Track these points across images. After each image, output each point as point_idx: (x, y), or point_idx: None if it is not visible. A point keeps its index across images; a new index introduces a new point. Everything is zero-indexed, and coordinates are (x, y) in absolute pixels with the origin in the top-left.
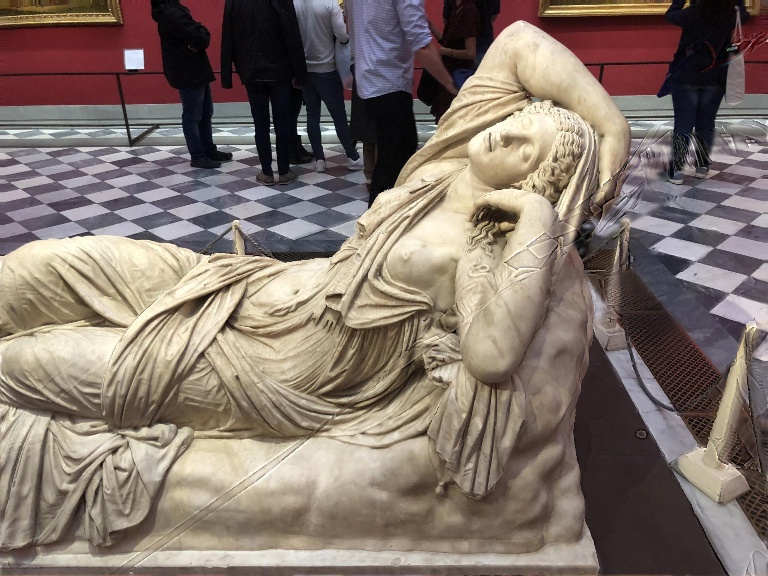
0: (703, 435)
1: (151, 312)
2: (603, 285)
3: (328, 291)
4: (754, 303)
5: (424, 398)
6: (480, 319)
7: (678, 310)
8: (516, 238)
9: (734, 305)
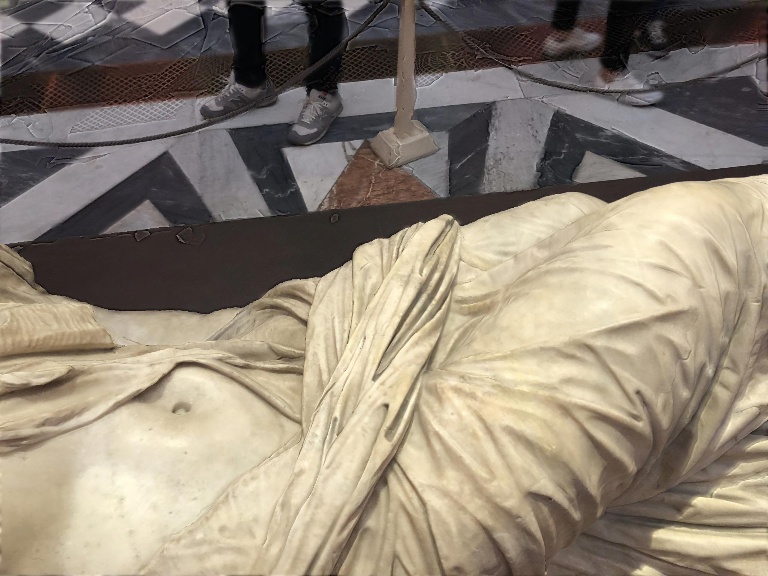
0: None
1: (418, 240)
2: None
3: (99, 327)
4: None
5: None
6: None
7: None
8: None
9: None
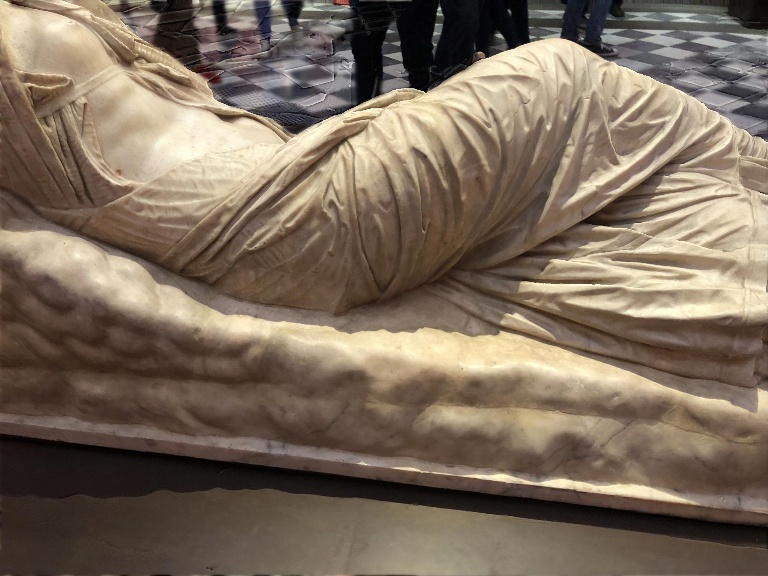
0: None
1: None
2: None
3: None
4: None
5: None
6: None
7: None
8: None
9: None
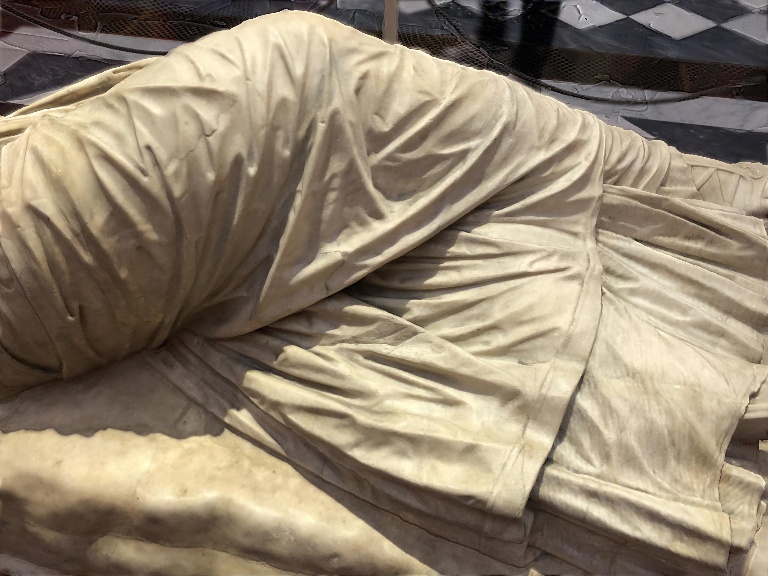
0: None
1: None
2: None
3: None
4: None
5: None
6: None
7: None
8: None
9: None
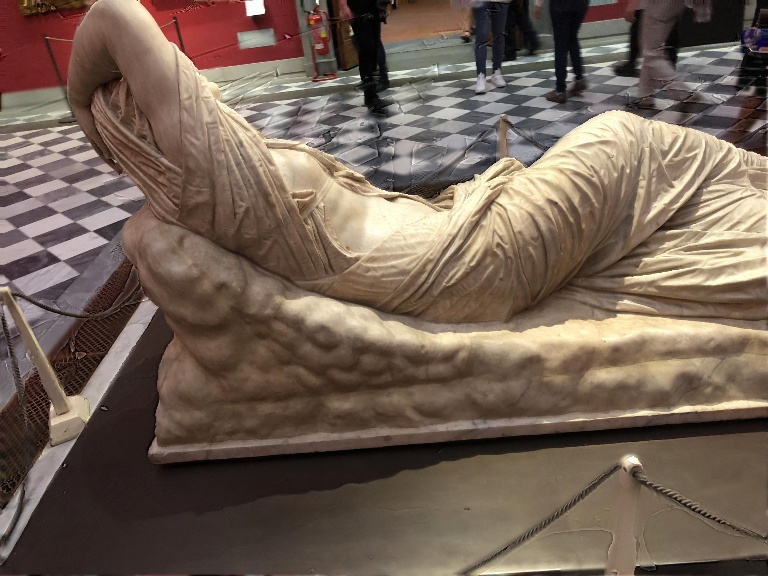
0: (19, 472)
1: None
2: None
3: None
4: None
5: None
6: None
7: None
8: None
9: None
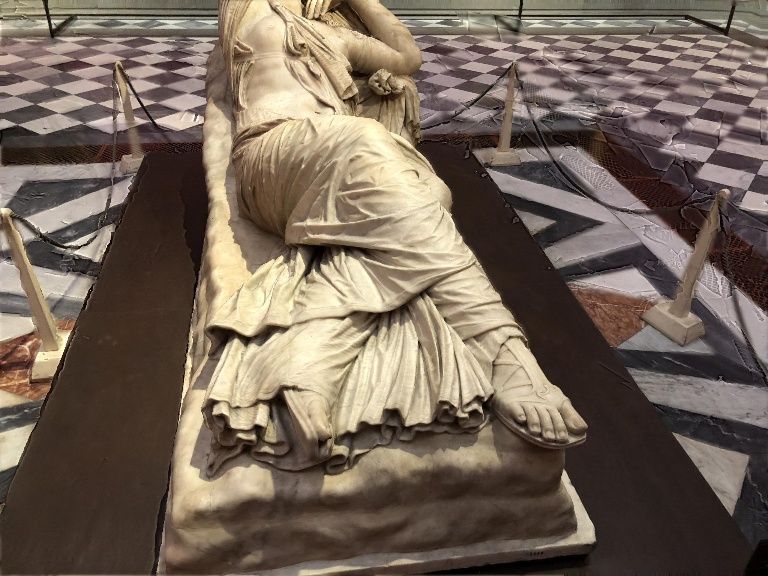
0: None
1: None
2: (34, 164)
3: (343, 88)
4: (104, 120)
5: (382, 119)
6: (407, 41)
7: (105, 141)
8: (372, 2)
9: (100, 127)
